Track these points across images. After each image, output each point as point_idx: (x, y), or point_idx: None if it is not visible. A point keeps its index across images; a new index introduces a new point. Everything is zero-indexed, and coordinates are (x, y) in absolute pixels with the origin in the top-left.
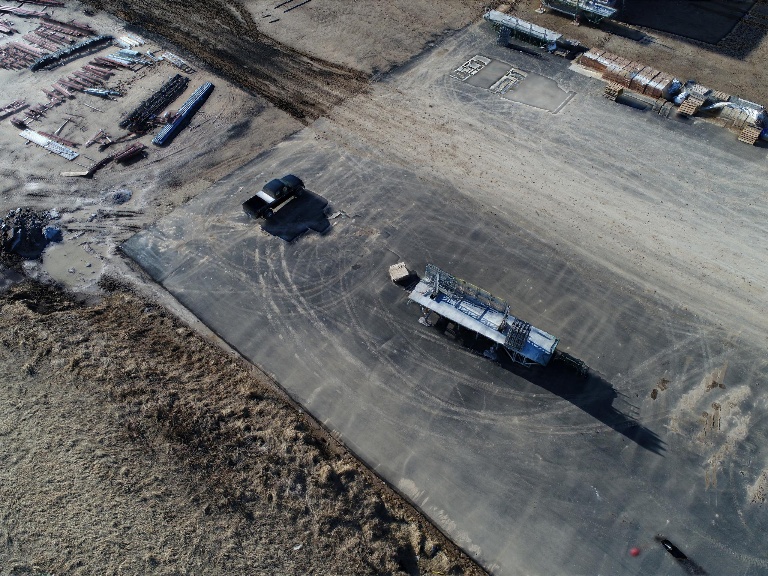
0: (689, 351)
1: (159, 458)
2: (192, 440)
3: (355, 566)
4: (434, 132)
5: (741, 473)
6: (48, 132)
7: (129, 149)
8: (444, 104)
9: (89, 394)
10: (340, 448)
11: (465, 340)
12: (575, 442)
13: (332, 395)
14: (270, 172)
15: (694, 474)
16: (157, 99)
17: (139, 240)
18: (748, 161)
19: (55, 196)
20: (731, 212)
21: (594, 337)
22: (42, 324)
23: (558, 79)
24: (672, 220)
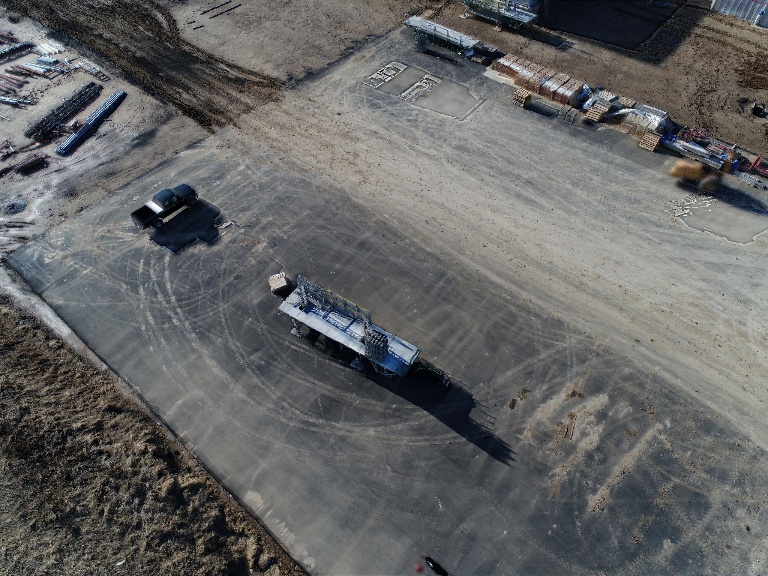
0: (554, 360)
1: None
2: (32, 455)
3: None
4: (338, 140)
5: (585, 483)
6: None
7: (30, 159)
8: (352, 111)
9: None
10: (192, 461)
11: (334, 351)
12: (427, 453)
13: (193, 407)
14: (168, 181)
15: (539, 484)
16: (67, 107)
17: (25, 251)
18: (645, 168)
19: None
20: (619, 219)
21: (462, 347)
22: None
23: (470, 85)
24: (559, 228)
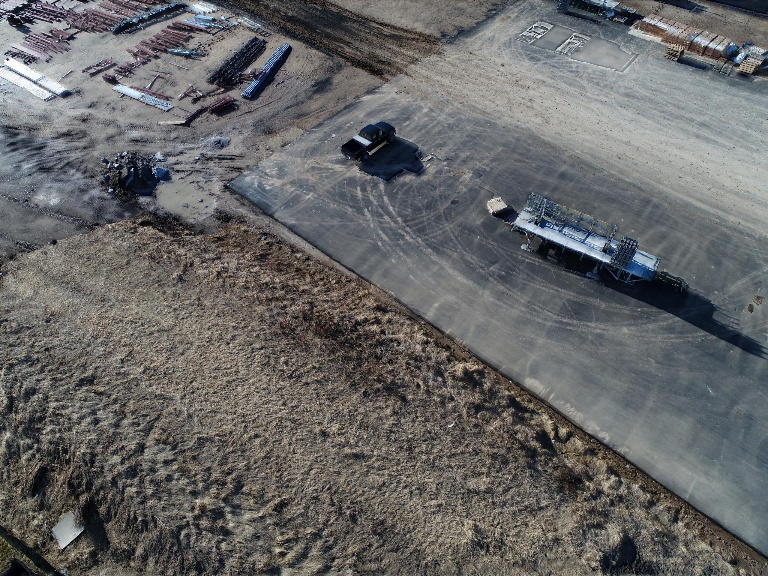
0: None
1: (313, 351)
2: (338, 338)
3: (504, 442)
4: (509, 87)
5: None
6: (139, 87)
7: (221, 101)
8: (515, 63)
9: (238, 298)
10: (465, 353)
11: (567, 263)
12: (683, 348)
13: (450, 309)
14: (359, 121)
15: None
16: (239, 58)
17: (245, 179)
18: None
19: (157, 142)
20: None
21: (688, 261)
22: (177, 244)
23: (620, 42)
24: (746, 163)
